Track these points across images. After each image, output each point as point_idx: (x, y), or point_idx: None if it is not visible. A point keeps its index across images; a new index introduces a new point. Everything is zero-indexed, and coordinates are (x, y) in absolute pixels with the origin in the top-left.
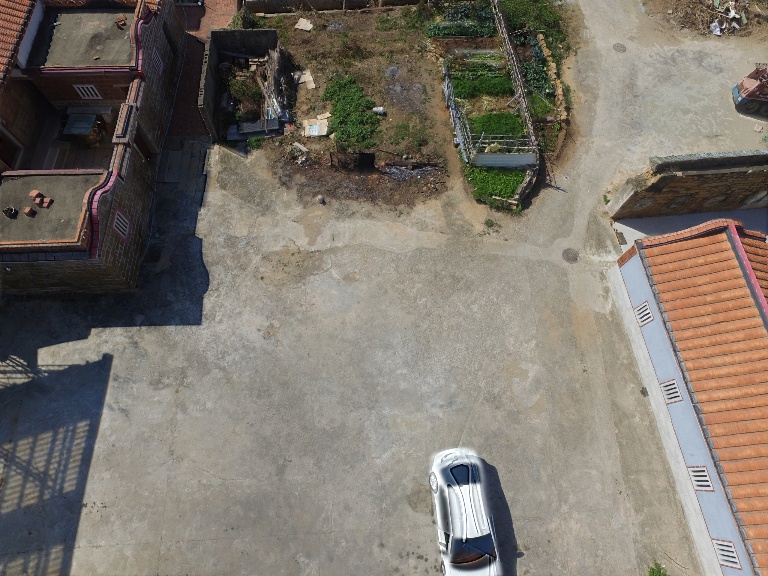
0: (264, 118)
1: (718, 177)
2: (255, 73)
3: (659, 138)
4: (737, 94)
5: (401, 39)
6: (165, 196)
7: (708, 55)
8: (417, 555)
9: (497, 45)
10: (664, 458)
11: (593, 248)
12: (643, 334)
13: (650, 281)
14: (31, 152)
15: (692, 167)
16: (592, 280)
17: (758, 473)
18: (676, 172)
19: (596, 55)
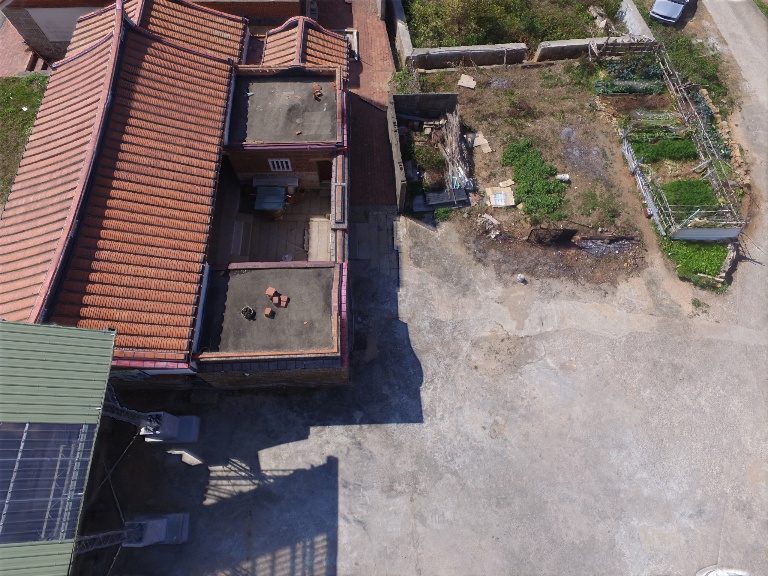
0: (449, 187)
1: None
2: (430, 137)
3: None
4: None
5: (570, 97)
6: (359, 275)
7: None
8: None
9: (668, 103)
10: None
11: None
12: None
13: None
14: (217, 227)
15: None
16: None
17: None
18: None
19: (761, 111)
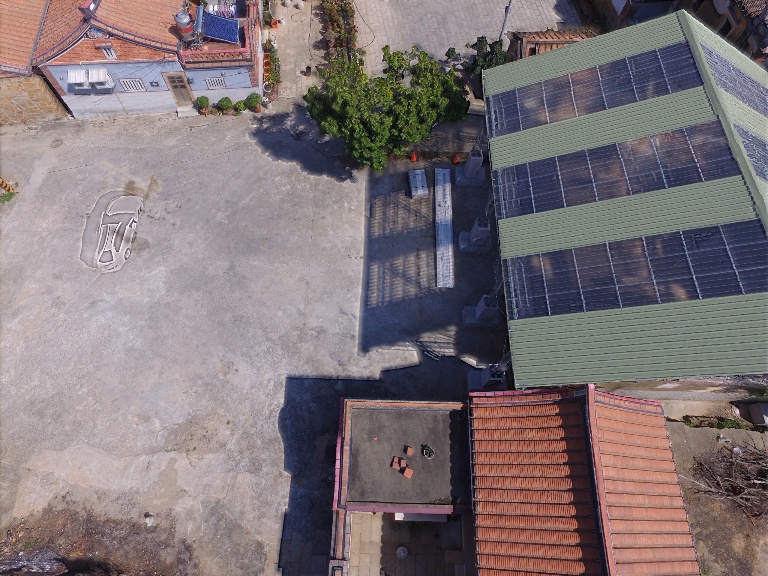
0: None
1: None
2: None
3: None
4: None
5: None
6: (325, 534)
7: None
8: (153, 218)
9: None
10: None
11: None
12: None
13: None
14: None
15: None
16: None
17: None
18: None
19: None
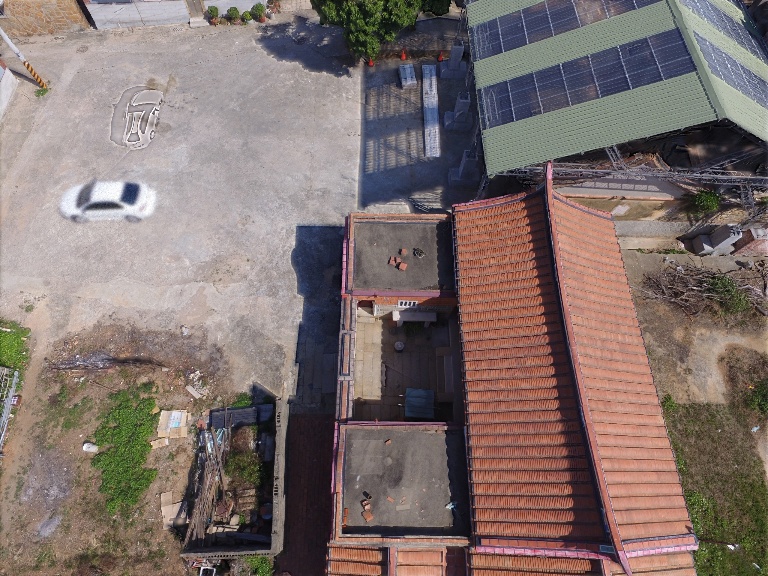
0: None
1: None
2: (234, 512)
3: None
4: None
5: None
6: (334, 339)
7: None
8: (173, 107)
9: None
10: None
11: None
12: None
13: None
14: None
15: None
16: None
17: None
18: None
19: None
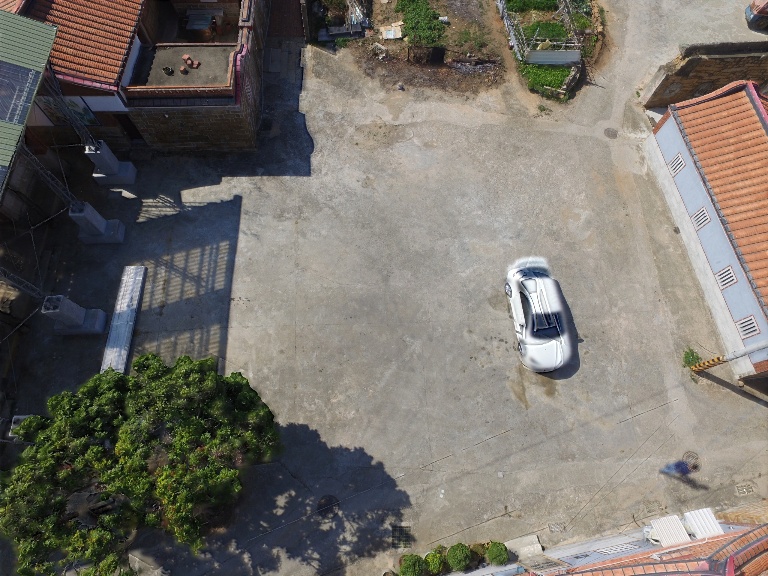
0: (348, 23)
1: (736, 61)
2: None
3: None
4: (749, 12)
5: None
6: (270, 82)
7: None
8: (499, 339)
9: None
10: (694, 277)
11: (630, 128)
12: (676, 182)
13: (682, 134)
14: None
15: (715, 52)
16: (630, 151)
17: None
18: (701, 55)
19: None
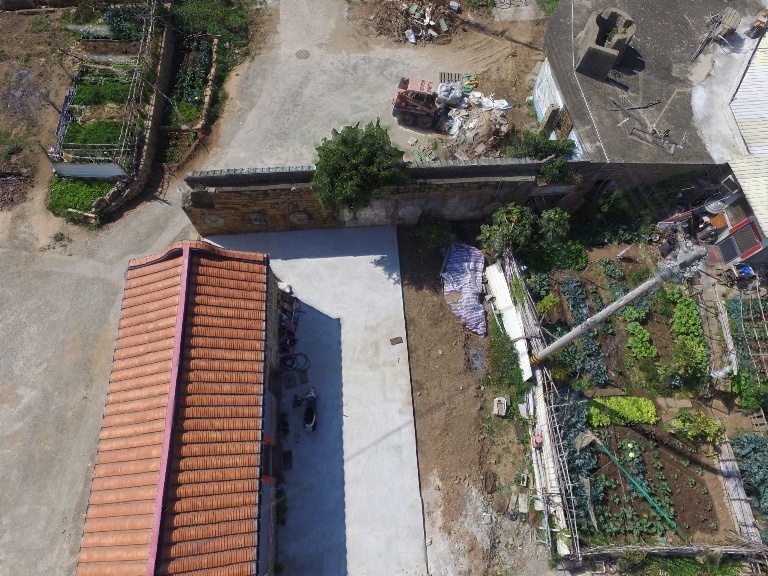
0: None
1: (261, 194)
2: None
3: (300, 150)
4: None
5: (45, 42)
6: None
7: (394, 63)
8: None
9: None
10: None
11: None
12: None
13: None
14: None
15: (229, 183)
16: None
17: (109, 520)
18: (209, 188)
19: (273, 61)
